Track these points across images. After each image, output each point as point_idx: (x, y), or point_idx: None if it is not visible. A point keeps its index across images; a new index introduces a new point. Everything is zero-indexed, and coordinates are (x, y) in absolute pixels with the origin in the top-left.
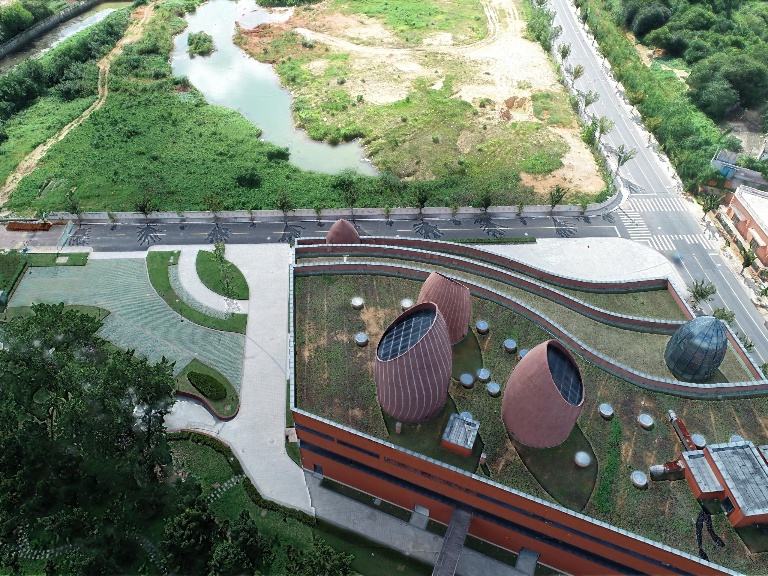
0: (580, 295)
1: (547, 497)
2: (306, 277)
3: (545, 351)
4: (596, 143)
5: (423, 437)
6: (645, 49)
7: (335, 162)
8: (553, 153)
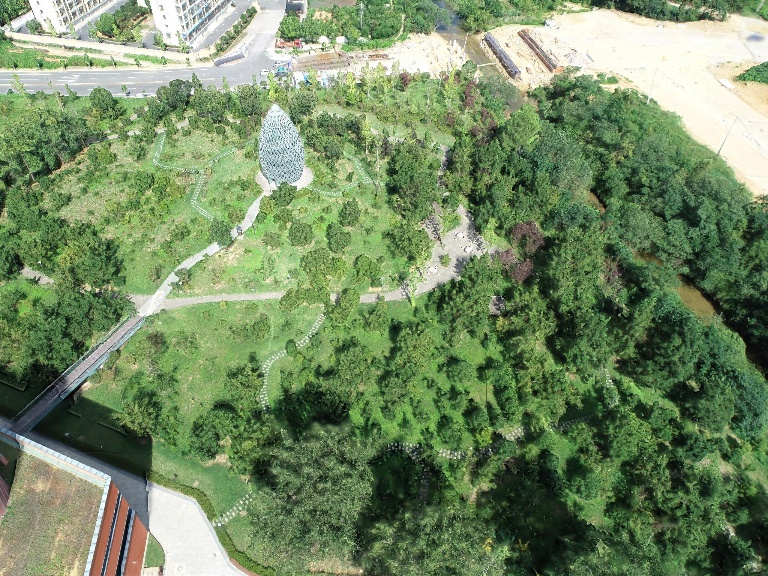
0: None
1: None
2: None
3: None
4: None
5: None
6: None
7: None
8: None
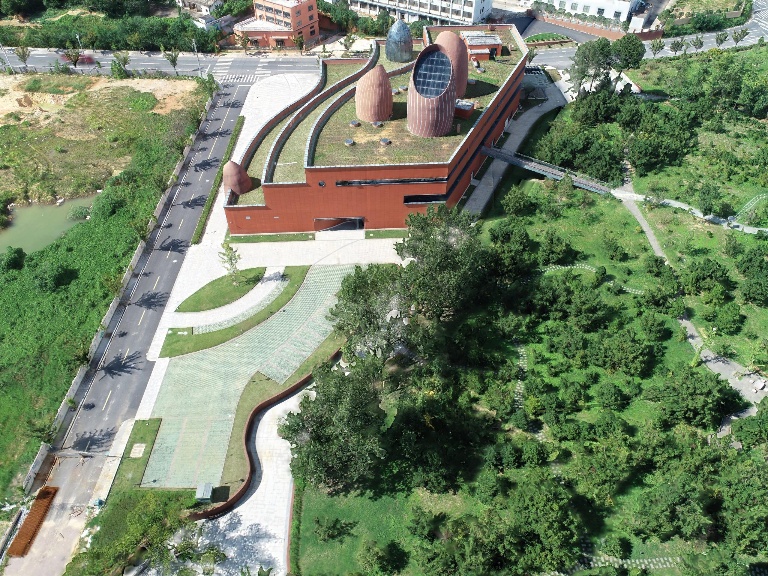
0: None
1: (493, 94)
2: None
3: None
4: (134, 72)
5: (461, 124)
6: (8, 21)
7: (49, 223)
8: (131, 94)
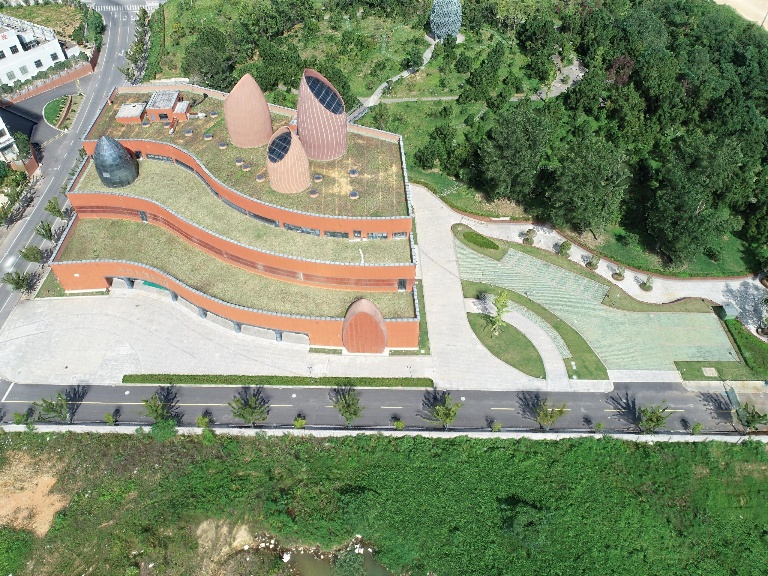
0: (144, 261)
1: None
2: None
3: None
4: None
5: None
6: None
7: None
8: None
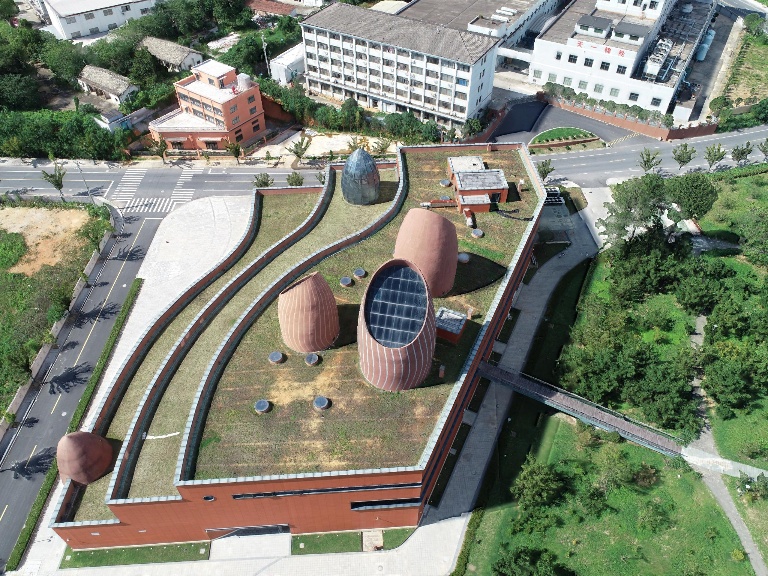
0: (255, 248)
1: (496, 284)
2: (196, 470)
3: (431, 212)
4: (4, 197)
5: (447, 357)
6: None
7: None
8: None
